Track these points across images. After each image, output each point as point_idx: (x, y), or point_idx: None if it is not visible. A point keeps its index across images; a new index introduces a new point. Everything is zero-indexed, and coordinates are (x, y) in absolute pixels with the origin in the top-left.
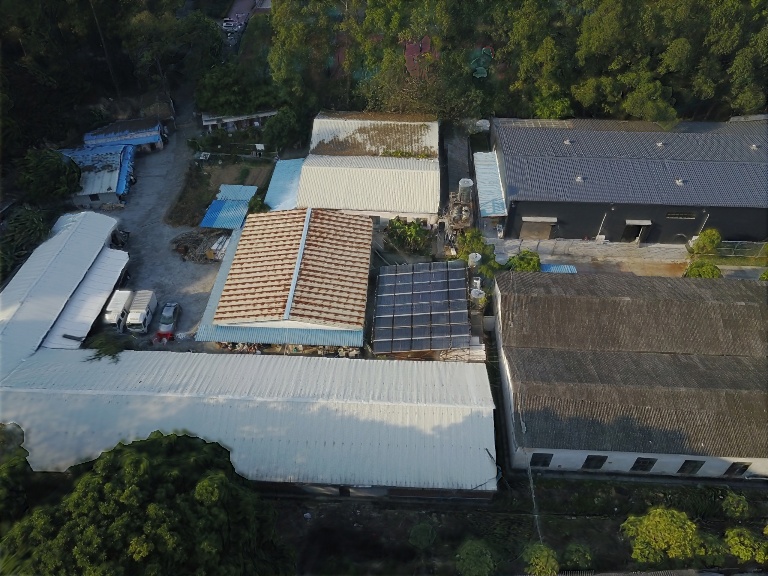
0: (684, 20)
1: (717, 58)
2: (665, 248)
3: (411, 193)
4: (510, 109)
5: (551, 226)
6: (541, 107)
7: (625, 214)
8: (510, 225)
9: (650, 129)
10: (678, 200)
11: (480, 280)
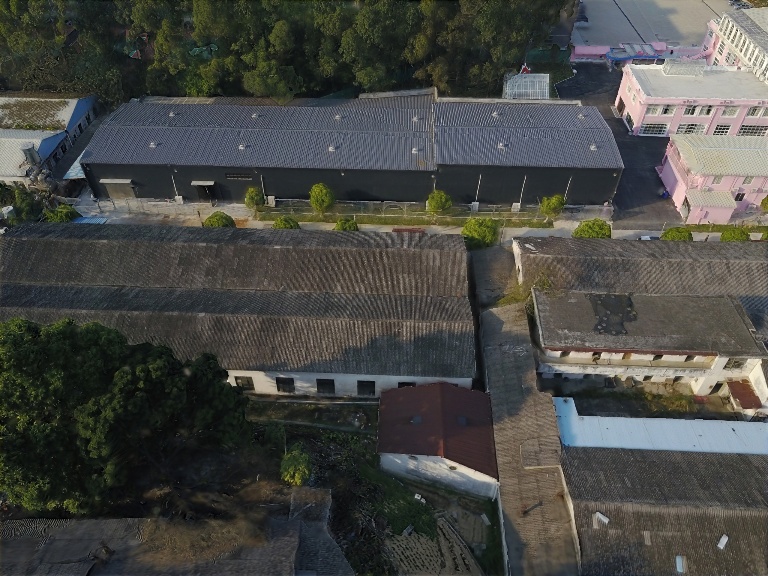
0: (281, 4)
1: (330, 39)
2: (238, 207)
3: (8, 159)
4: (173, 89)
5: (132, 188)
6: (190, 86)
7: (190, 176)
8: (96, 187)
9: (279, 105)
10: (229, 162)
11: (5, 229)
